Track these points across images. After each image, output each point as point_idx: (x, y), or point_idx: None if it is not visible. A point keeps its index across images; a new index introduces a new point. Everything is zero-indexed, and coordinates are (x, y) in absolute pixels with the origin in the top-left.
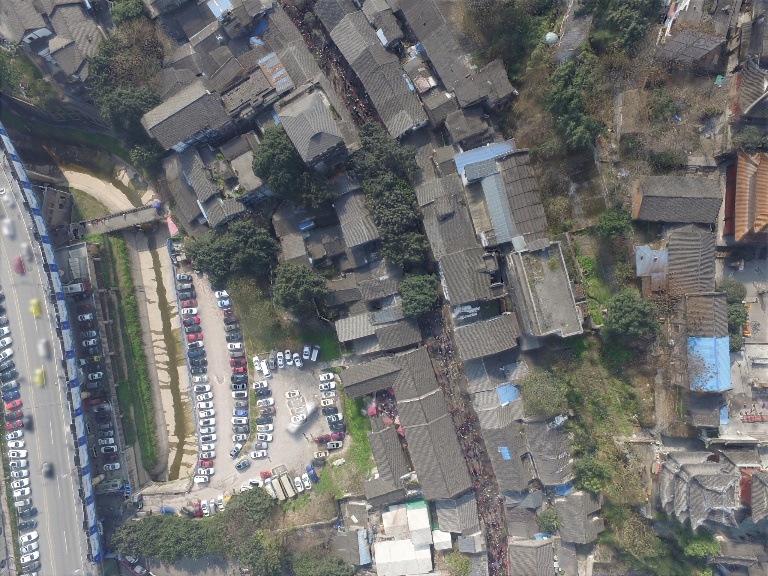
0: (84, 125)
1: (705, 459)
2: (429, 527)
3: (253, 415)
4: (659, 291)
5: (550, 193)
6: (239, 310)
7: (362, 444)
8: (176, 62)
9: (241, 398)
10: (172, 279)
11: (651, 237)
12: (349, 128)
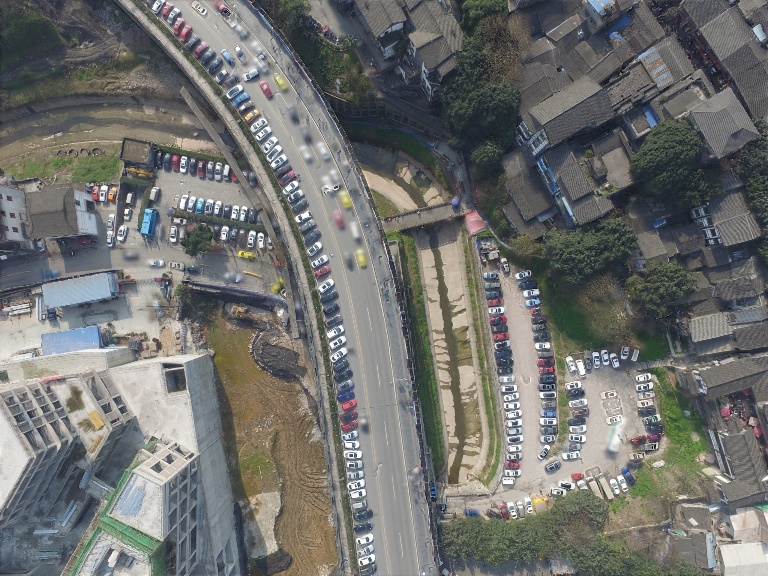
0: (380, 121)
1: None
2: None
3: (562, 416)
4: None
5: None
6: (597, 309)
7: (685, 446)
8: (536, 57)
9: (550, 399)
10: (454, 278)
11: None
12: None
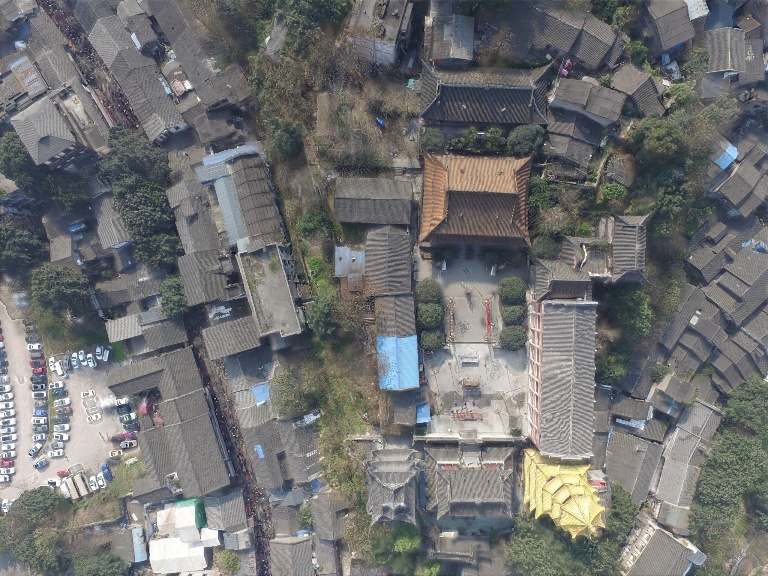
0: None
1: (408, 456)
2: (195, 525)
3: (52, 415)
4: (356, 291)
5: (289, 195)
6: (7, 311)
7: None
8: None
9: (40, 398)
10: None
11: (361, 238)
12: (101, 131)
